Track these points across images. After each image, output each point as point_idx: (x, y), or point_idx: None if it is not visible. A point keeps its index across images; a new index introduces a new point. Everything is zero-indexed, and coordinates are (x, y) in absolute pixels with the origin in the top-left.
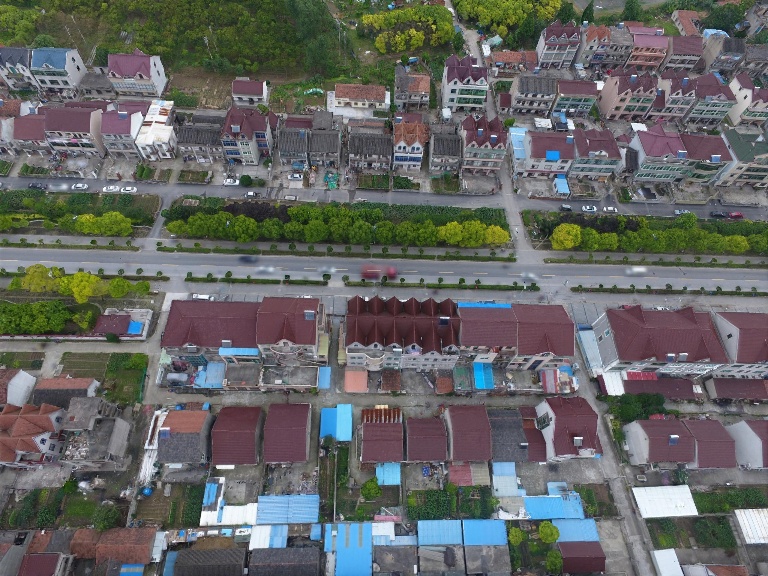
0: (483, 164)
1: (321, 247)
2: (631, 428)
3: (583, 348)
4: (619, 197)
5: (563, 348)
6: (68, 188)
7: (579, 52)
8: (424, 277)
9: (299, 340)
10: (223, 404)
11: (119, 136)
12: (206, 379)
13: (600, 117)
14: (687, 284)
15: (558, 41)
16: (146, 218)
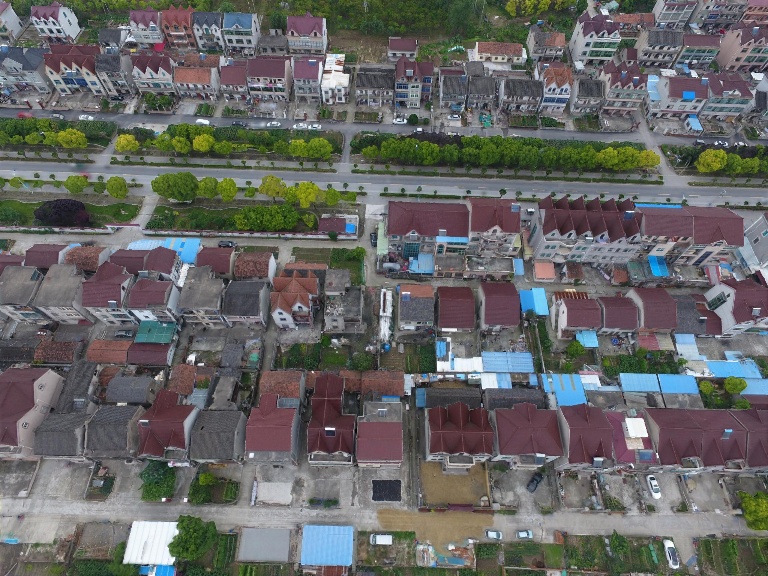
0: (622, 105)
1: (489, 171)
2: None
3: (738, 251)
4: (747, 135)
5: (734, 239)
6: (264, 126)
7: (694, 12)
8: None
9: (506, 229)
10: (433, 287)
11: (307, 81)
12: (419, 266)
13: (719, 69)
14: None
15: (677, 2)
16: (337, 147)
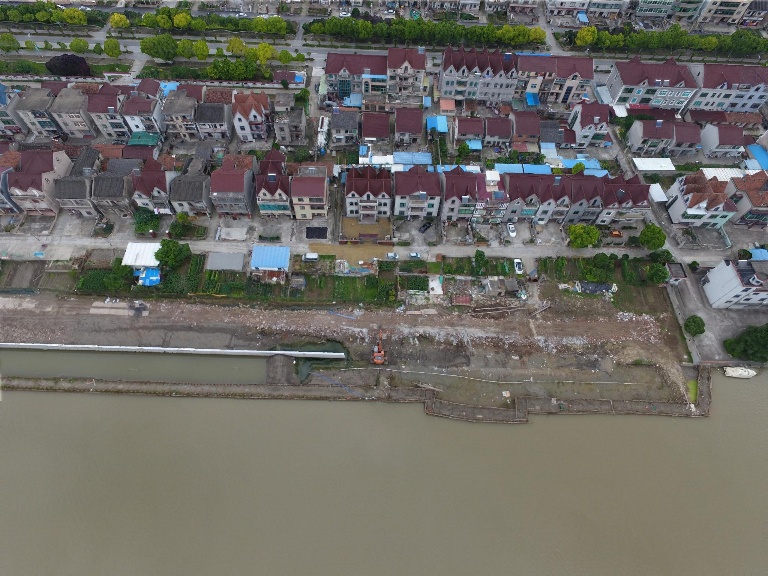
0: (525, 2)
1: (414, 47)
2: (632, 129)
3: (599, 96)
4: None
5: (586, 74)
6: None
7: None
8: None
9: (415, 66)
10: None
11: None
12: (350, 102)
13: None
14: None
15: None
16: (292, 30)
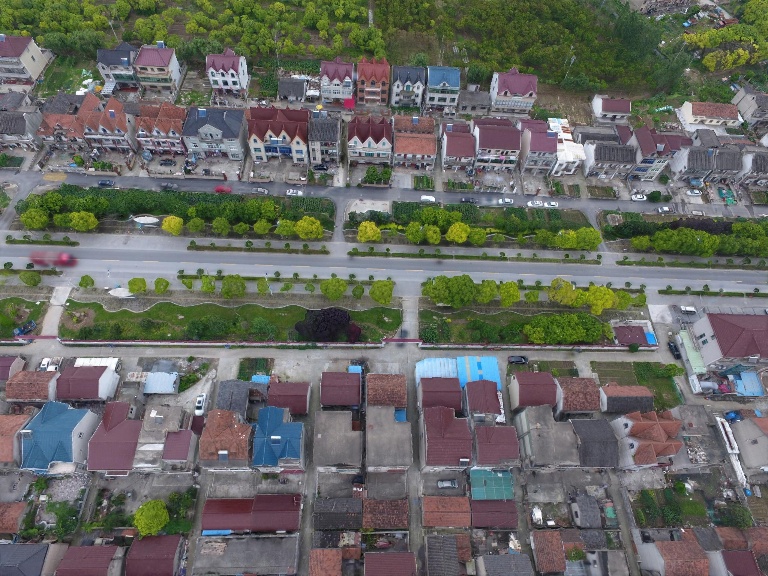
0: None
1: None
2: None
3: None
4: None
5: None
6: (495, 203)
7: None
8: None
9: None
10: (760, 411)
11: (543, 153)
12: (745, 387)
13: None
14: None
15: None
16: None
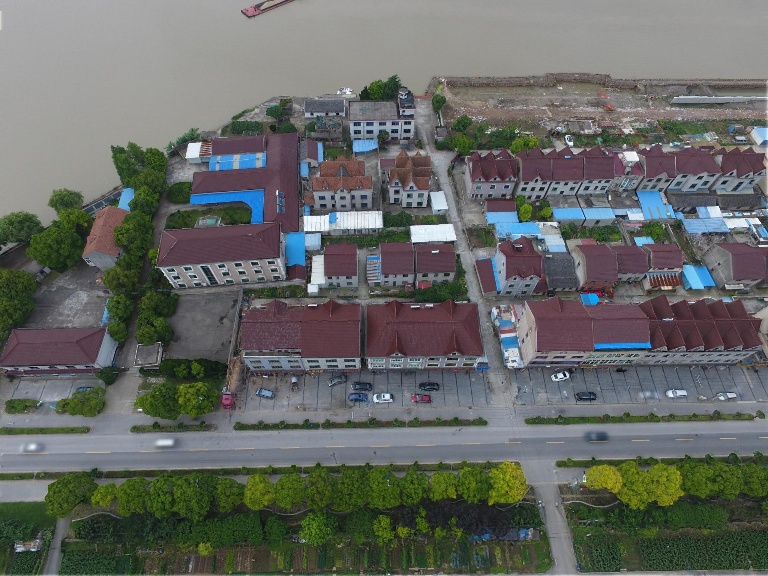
0: None
1: None
2: None
3: None
4: None
5: (539, 305)
6: None
7: None
8: (666, 432)
9: None
10: None
11: None
12: None
13: None
14: (336, 439)
15: None
16: None
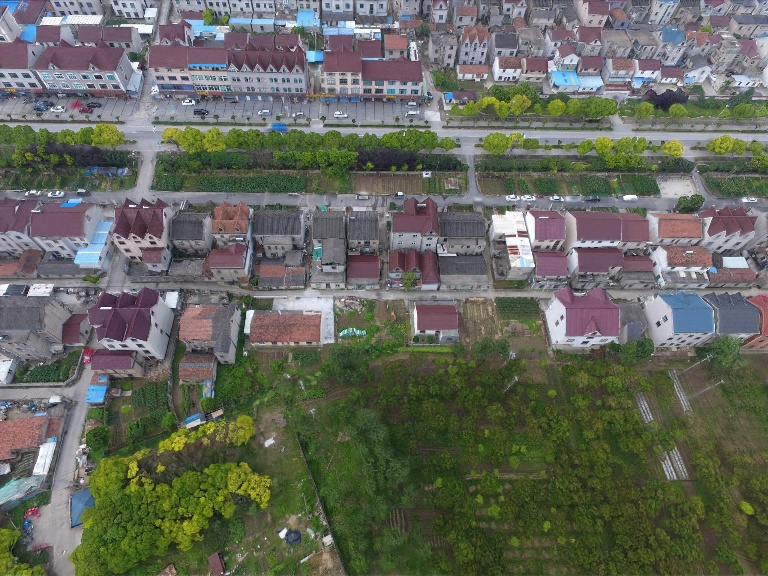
0: None
1: None
2: None
3: None
4: None
5: None
6: (566, 199)
7: None
8: None
9: None
10: None
11: None
12: None
13: None
14: None
15: None
16: None
